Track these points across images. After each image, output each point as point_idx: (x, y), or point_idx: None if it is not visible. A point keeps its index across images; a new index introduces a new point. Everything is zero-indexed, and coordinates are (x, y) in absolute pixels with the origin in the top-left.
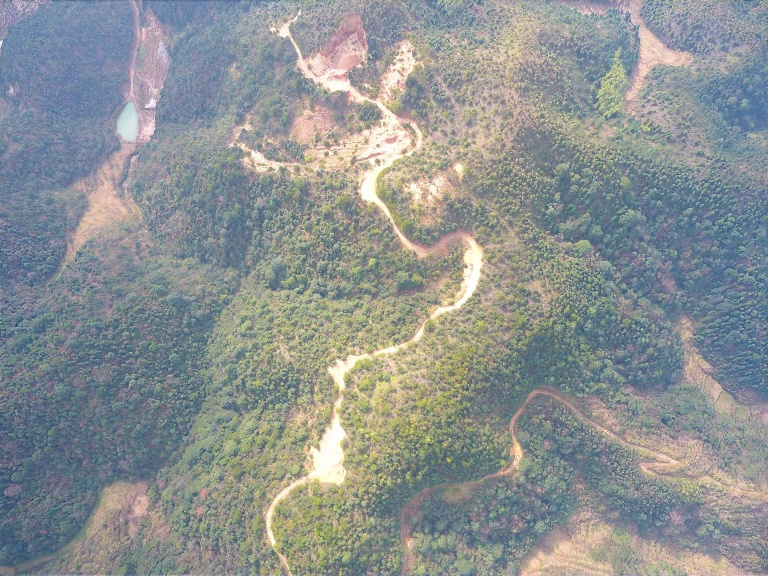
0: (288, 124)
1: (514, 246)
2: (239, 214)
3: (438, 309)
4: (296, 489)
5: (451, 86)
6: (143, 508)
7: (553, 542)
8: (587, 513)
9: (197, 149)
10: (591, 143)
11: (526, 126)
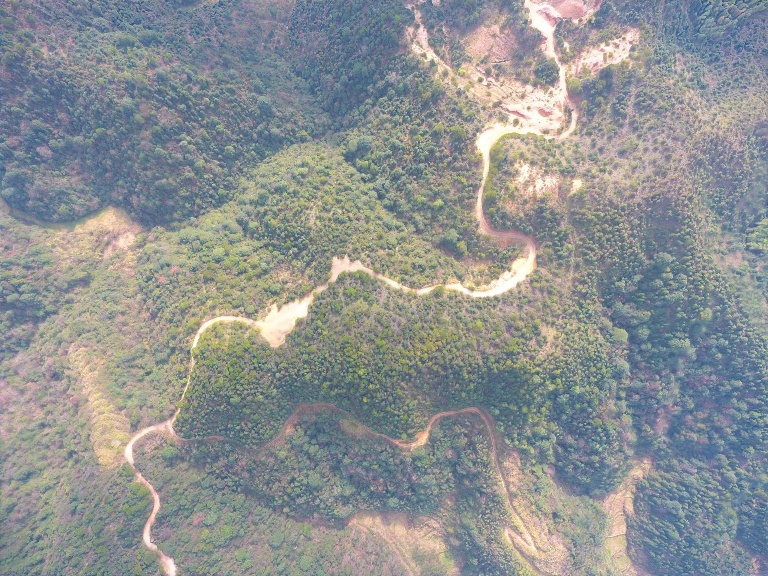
0: (471, 26)
1: (562, 287)
2: (368, 74)
3: (457, 284)
4: (239, 323)
5: (638, 106)
6: (127, 243)
7: (394, 520)
8: (437, 523)
9: None
10: (710, 258)
11: (668, 196)
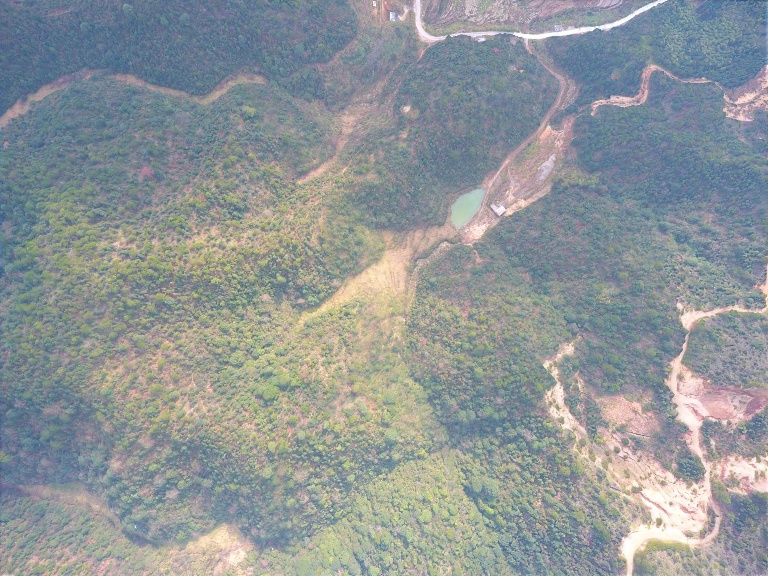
0: (610, 393)
1: None
2: (499, 418)
3: None
4: None
5: None
6: (237, 559)
7: None
8: None
9: (517, 337)
10: None
11: None
